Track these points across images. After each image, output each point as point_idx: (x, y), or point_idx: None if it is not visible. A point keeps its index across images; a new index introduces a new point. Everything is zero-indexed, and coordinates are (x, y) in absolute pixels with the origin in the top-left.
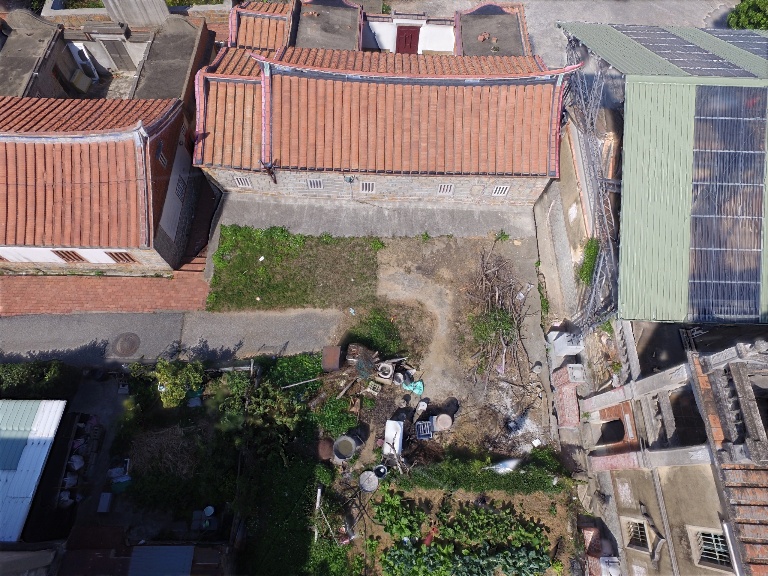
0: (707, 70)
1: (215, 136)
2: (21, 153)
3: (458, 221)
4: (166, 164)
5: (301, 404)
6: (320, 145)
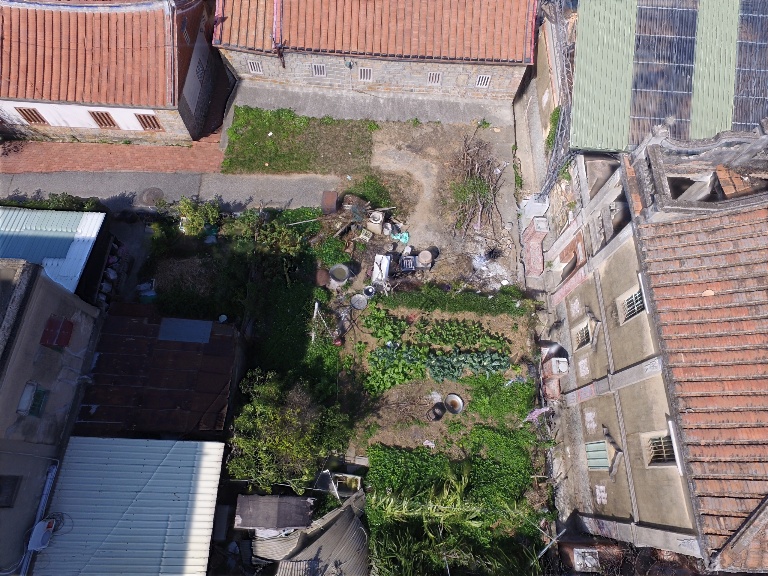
0: None
1: (232, 20)
2: (65, 20)
3: (445, 110)
4: (189, 42)
5: (303, 241)
6: (324, 29)
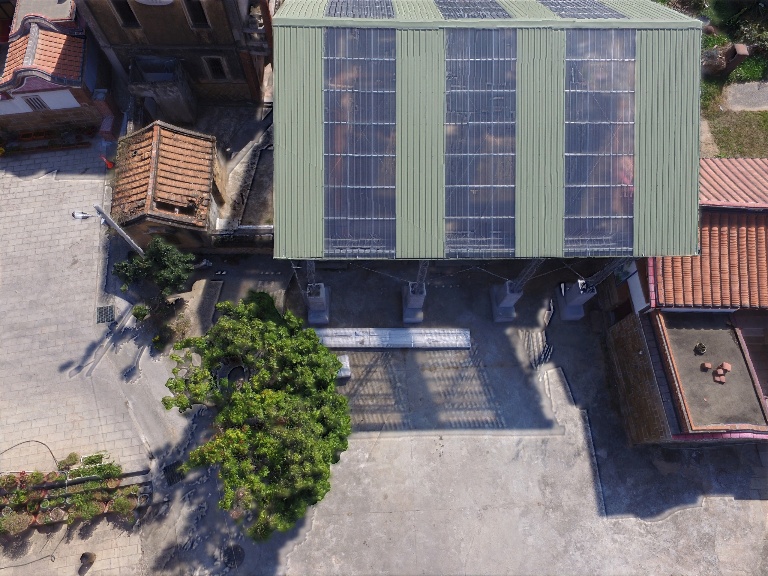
0: (610, 51)
1: None
2: None
3: None
4: None
5: None
6: None
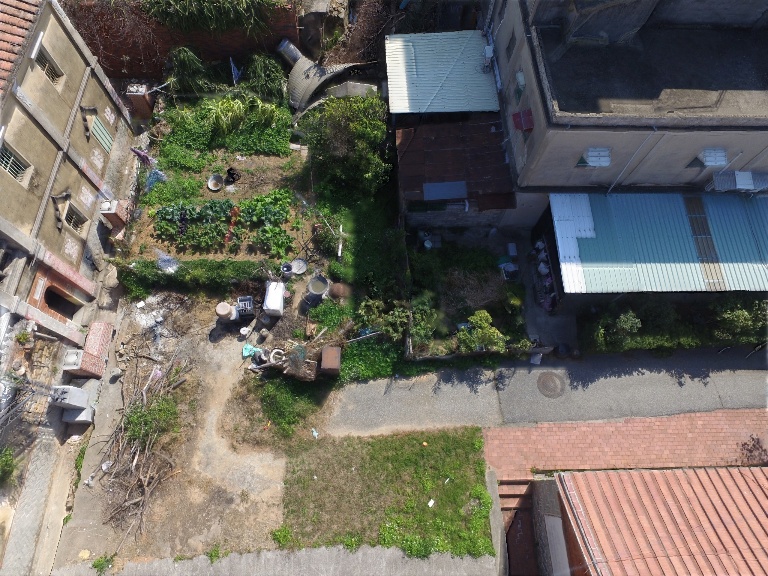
0: None
1: None
2: None
3: None
4: None
5: None
6: None
